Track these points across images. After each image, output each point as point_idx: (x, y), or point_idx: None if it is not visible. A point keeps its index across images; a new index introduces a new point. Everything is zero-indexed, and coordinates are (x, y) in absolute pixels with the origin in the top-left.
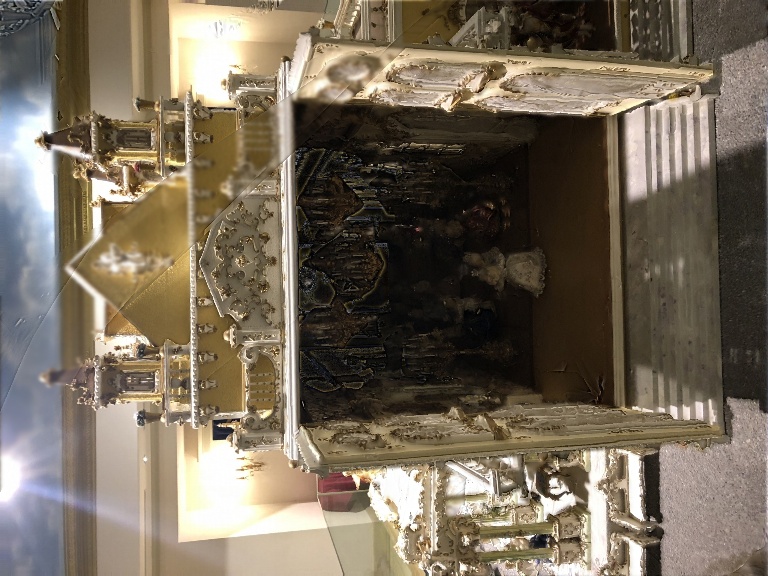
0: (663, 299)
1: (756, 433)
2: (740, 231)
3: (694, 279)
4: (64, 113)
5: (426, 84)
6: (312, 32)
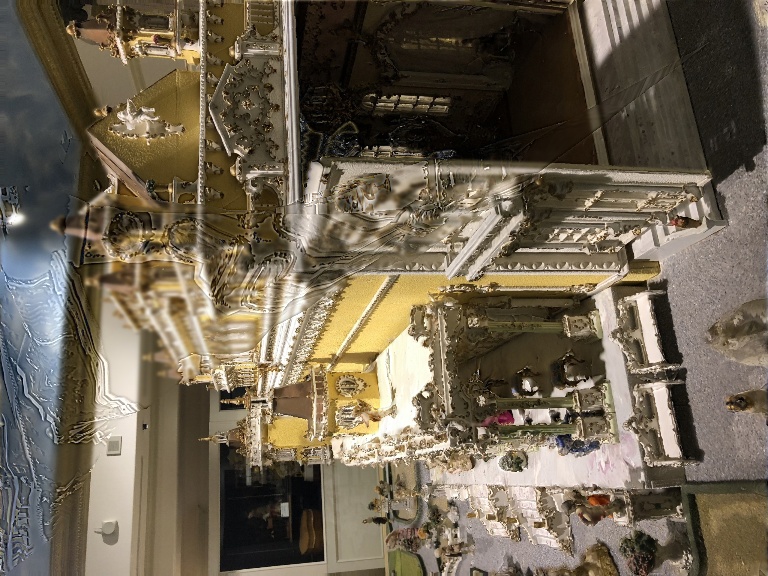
0: (642, 127)
1: (749, 196)
2: (696, 37)
3: (666, 99)
4: (87, 118)
5: None
6: None
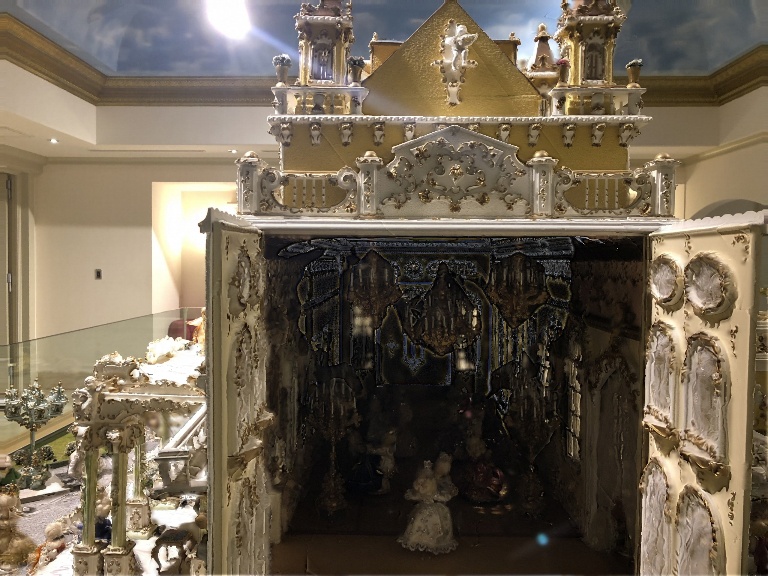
0: None
1: None
2: None
3: None
4: None
5: (686, 387)
6: (766, 226)
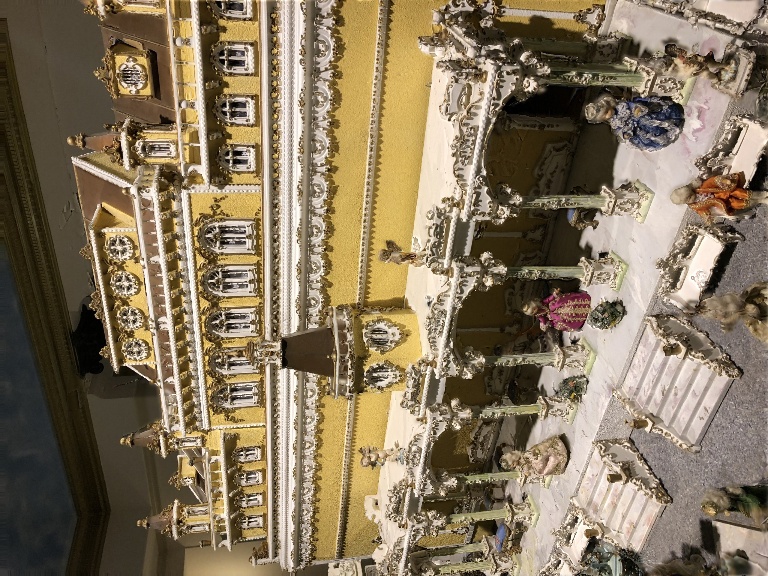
0: None
1: None
2: None
3: None
4: None
5: None
6: None
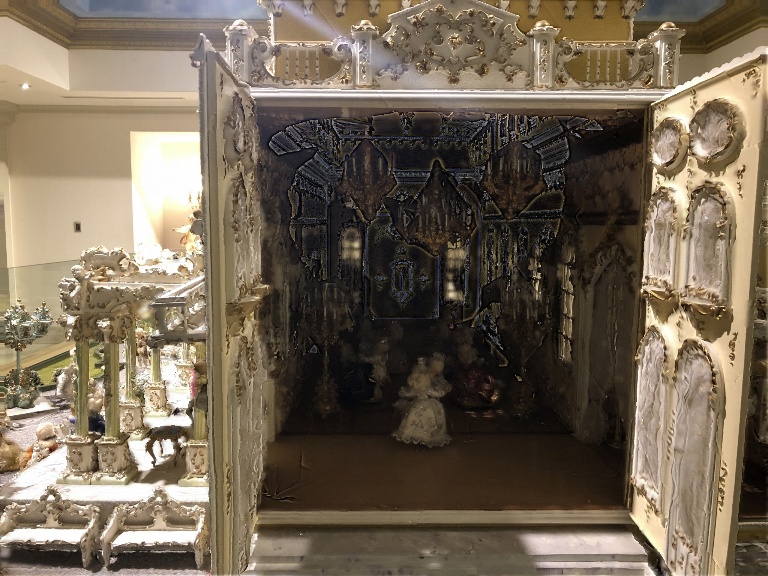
0: (397, 572)
1: None
2: None
3: None
4: None
5: (688, 243)
6: None
